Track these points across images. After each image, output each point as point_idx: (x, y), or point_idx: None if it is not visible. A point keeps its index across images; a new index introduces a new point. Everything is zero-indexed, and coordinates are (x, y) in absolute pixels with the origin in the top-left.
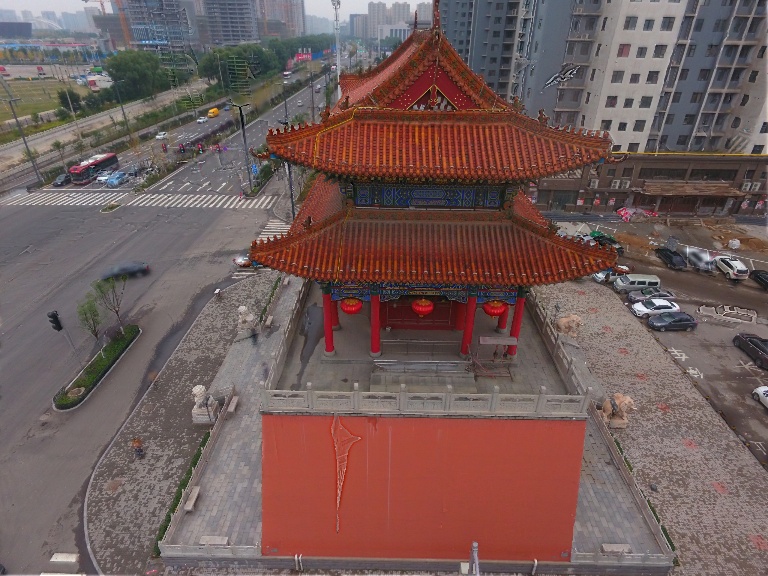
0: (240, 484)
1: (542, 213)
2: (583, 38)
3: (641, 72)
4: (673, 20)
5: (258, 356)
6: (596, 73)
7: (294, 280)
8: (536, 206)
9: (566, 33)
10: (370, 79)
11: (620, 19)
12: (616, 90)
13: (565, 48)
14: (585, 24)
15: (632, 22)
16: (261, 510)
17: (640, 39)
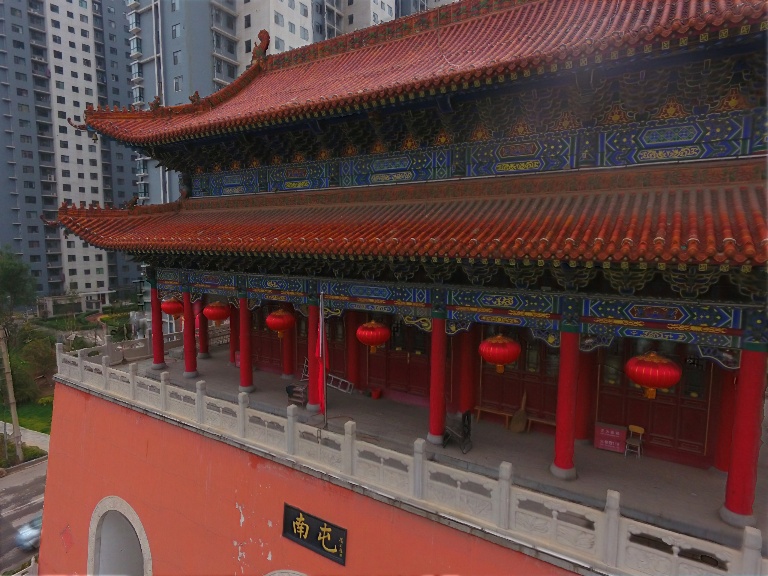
0: None
1: None
2: None
3: None
4: None
5: None
6: None
7: None
8: None
9: None
10: (199, 114)
11: None
12: None
13: None
14: None
15: None
16: None
17: None
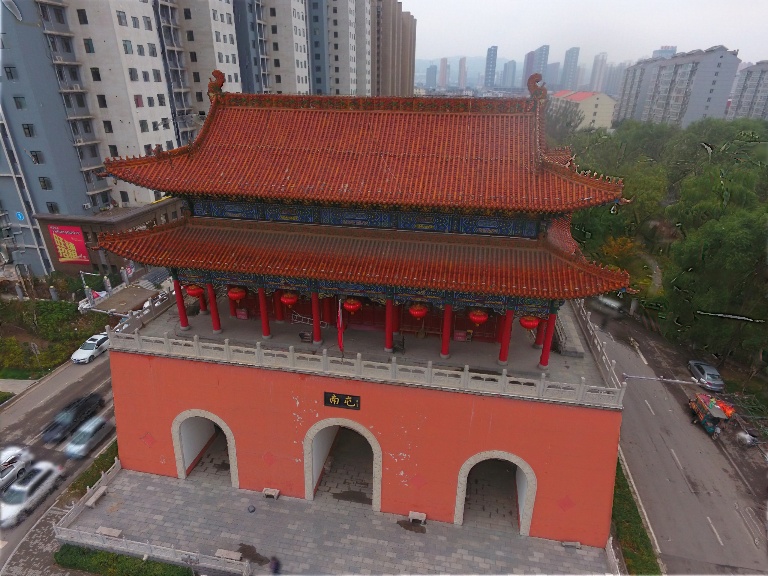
0: (538, 575)
1: (147, 277)
2: (76, 89)
3: (157, 120)
4: (159, 72)
5: (312, 572)
6: (114, 125)
7: (105, 524)
8: (136, 274)
9: (55, 84)
10: (194, 157)
11: (124, 70)
12: (148, 139)
13: (62, 101)
14: (69, 74)
15: (133, 73)
16: (564, 552)
17: (145, 89)
